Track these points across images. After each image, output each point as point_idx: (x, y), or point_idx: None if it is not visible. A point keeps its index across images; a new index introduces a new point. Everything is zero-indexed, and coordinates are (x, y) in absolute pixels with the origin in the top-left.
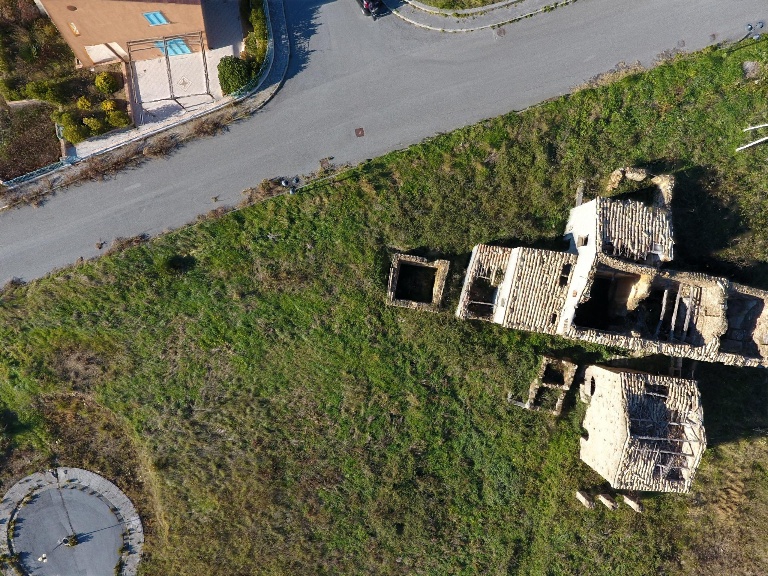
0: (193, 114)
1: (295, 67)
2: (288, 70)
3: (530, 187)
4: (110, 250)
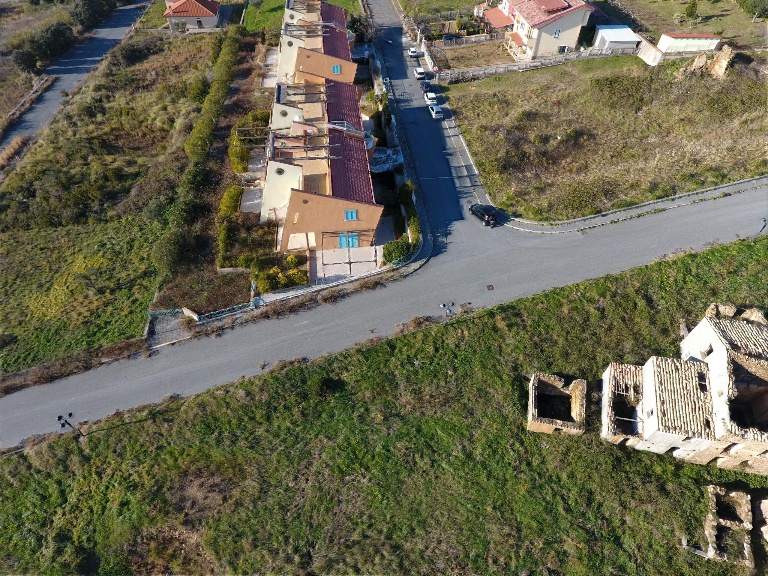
0: (360, 275)
1: (437, 251)
2: (432, 252)
3: (639, 325)
4: (272, 369)
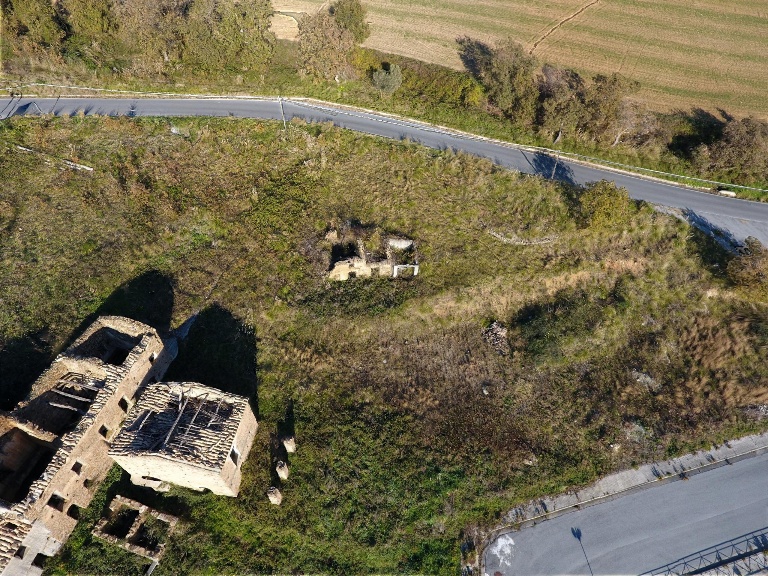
0: None
1: None
2: None
3: None
4: None
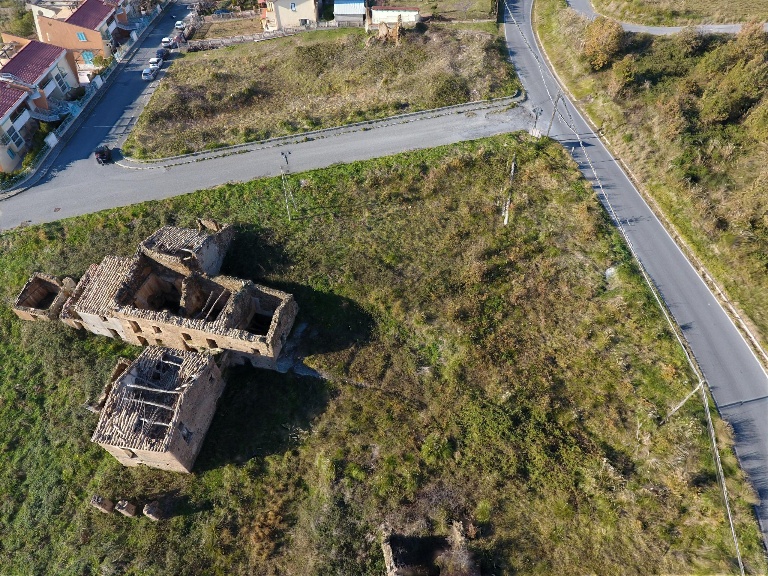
0: None
1: (42, 182)
2: (37, 183)
3: None
4: None
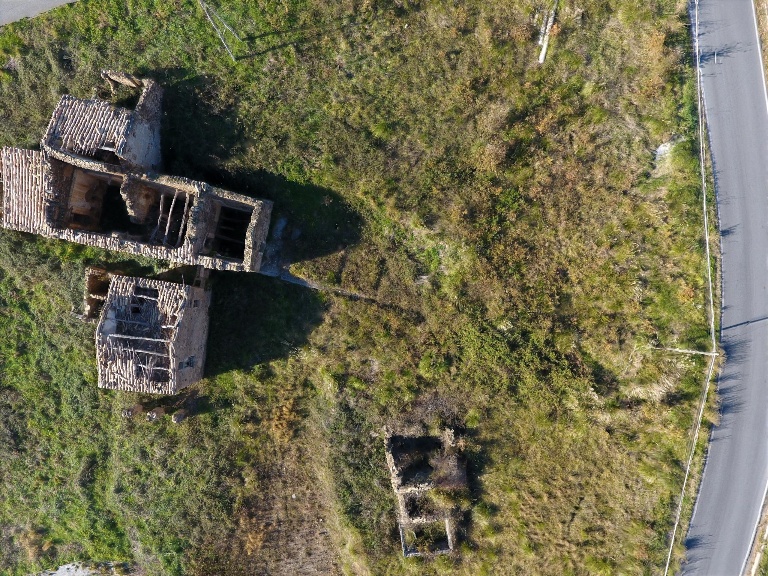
0: None
1: None
2: None
3: (51, 95)
4: None
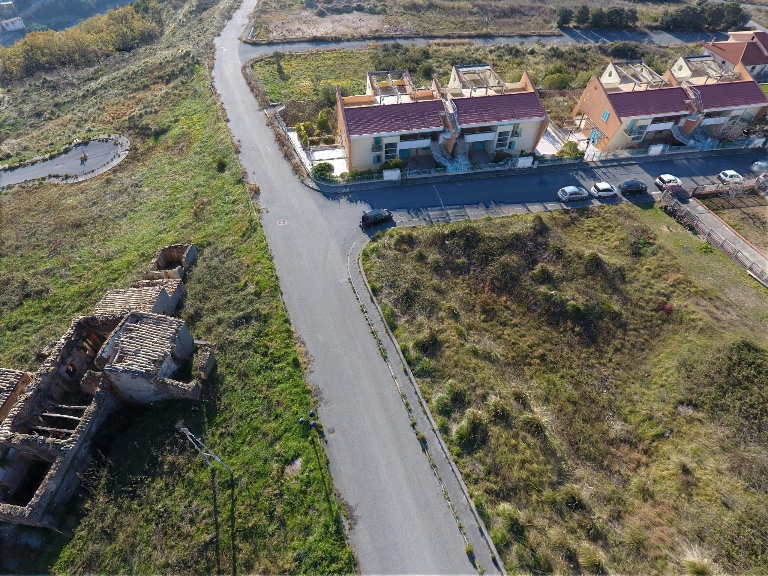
0: None
1: (329, 195)
2: (328, 193)
3: None
4: (235, 143)
